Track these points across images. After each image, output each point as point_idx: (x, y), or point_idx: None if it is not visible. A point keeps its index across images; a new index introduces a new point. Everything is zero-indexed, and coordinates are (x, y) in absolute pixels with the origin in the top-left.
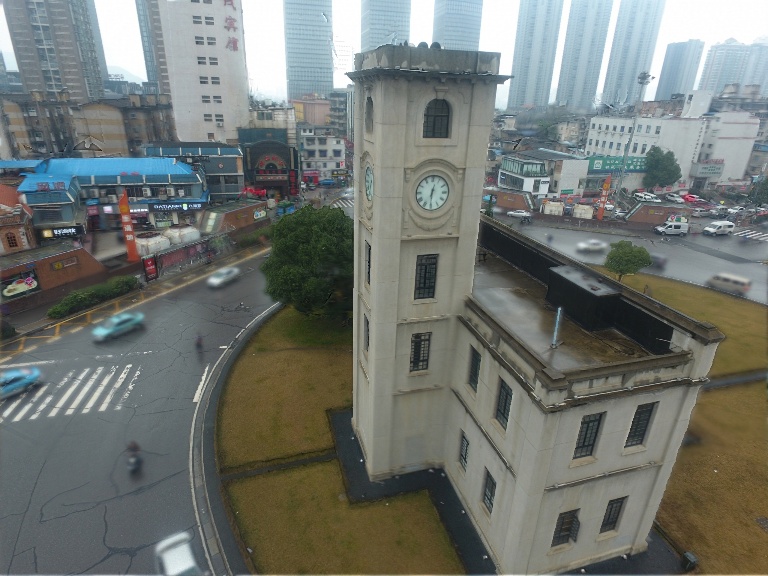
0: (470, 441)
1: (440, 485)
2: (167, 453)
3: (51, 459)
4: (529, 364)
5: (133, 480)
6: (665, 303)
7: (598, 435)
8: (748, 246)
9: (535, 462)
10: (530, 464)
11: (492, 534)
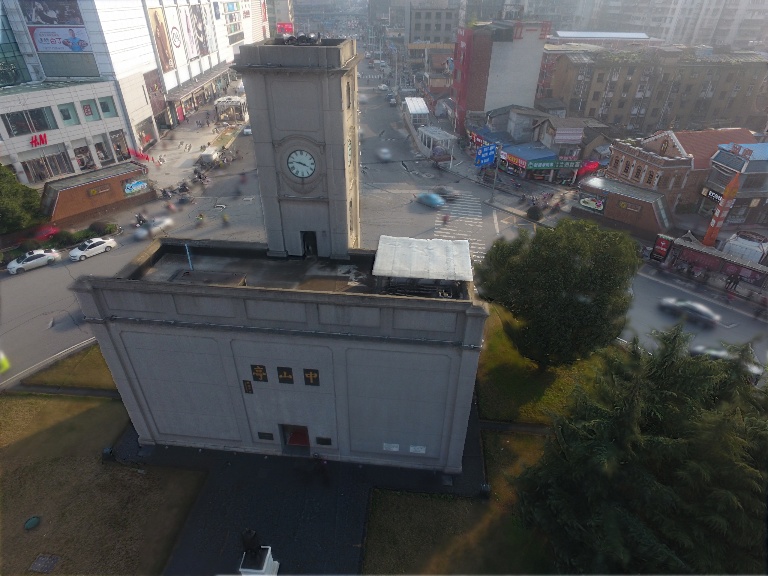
0: None
1: None
2: None
3: None
4: None
5: None
6: None
7: None
8: None
9: None
10: None
11: None
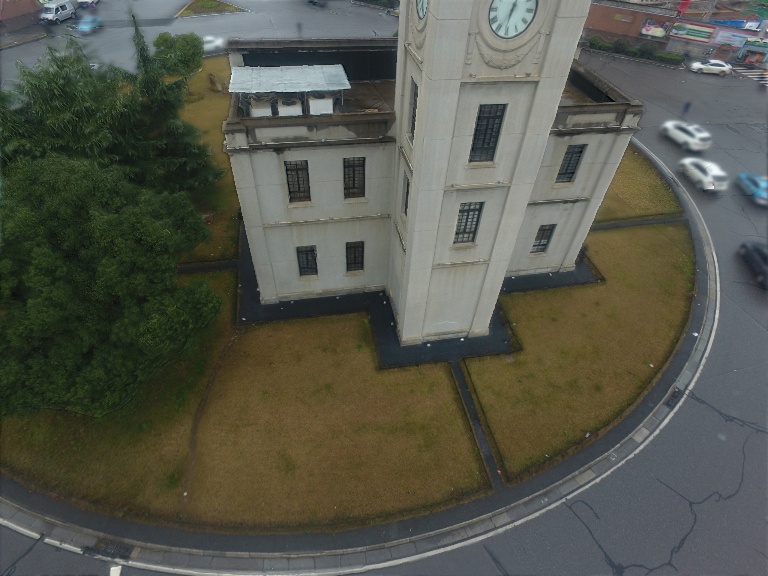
0: None
1: None
2: None
3: None
4: (611, 112)
5: None
6: None
7: None
8: (137, 6)
9: None
10: (610, 177)
11: (549, 259)
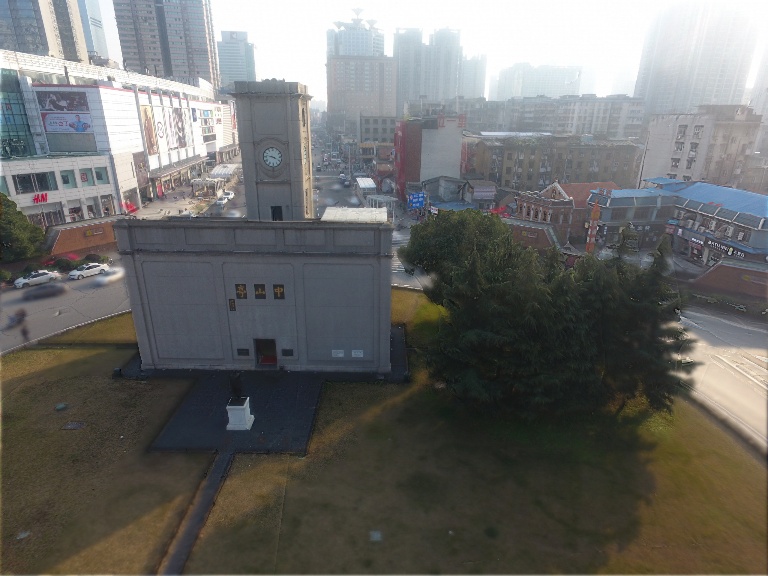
0: None
1: None
2: None
3: None
4: None
5: None
6: None
7: None
8: None
9: None
10: None
11: None
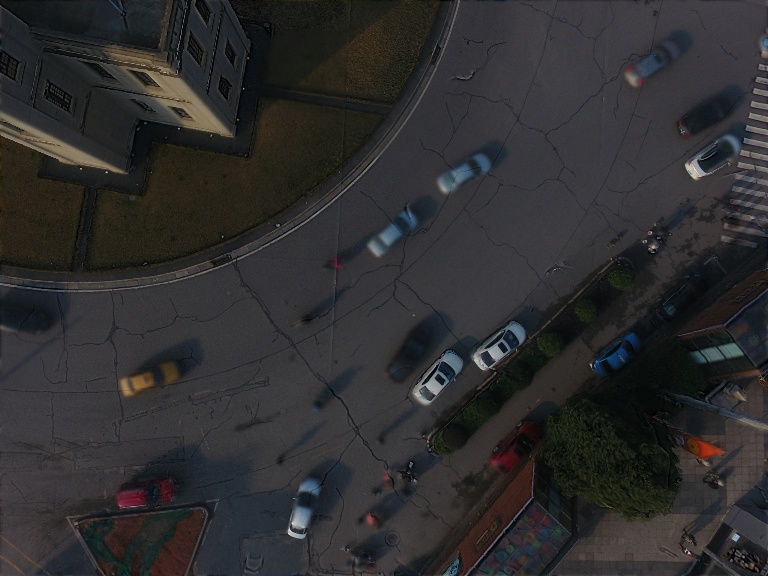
0: (143, 101)
1: (152, 130)
2: (33, 306)
3: (3, 386)
4: (141, 58)
5: (52, 329)
6: None
7: (197, 42)
8: None
9: (195, 94)
10: (193, 96)
11: (203, 125)
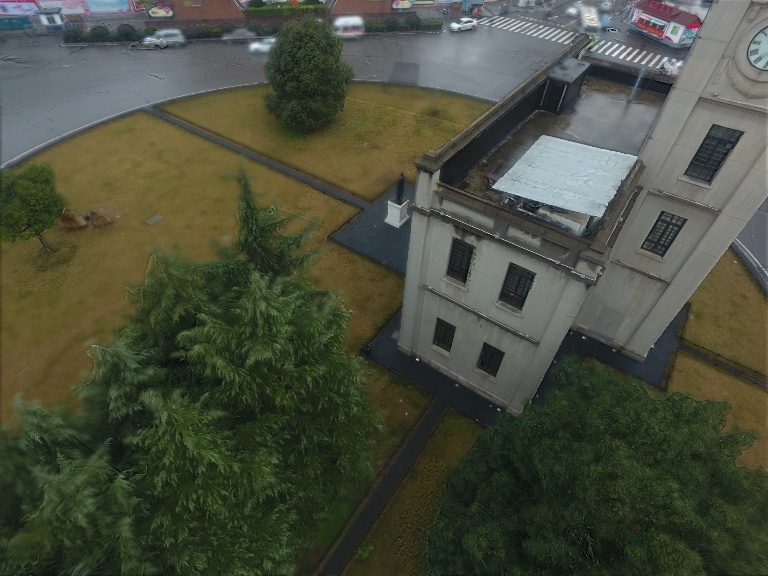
0: None
1: None
2: None
3: None
4: None
5: None
6: (85, 209)
7: None
8: None
9: None
10: None
11: None
